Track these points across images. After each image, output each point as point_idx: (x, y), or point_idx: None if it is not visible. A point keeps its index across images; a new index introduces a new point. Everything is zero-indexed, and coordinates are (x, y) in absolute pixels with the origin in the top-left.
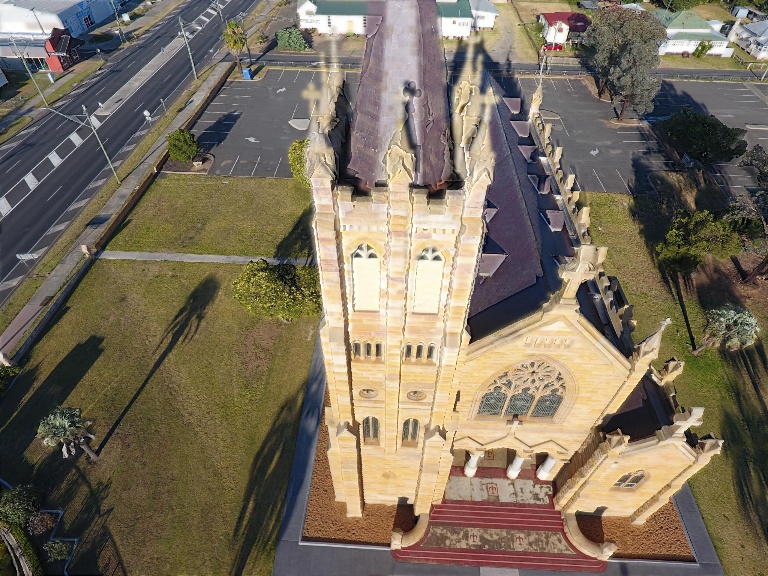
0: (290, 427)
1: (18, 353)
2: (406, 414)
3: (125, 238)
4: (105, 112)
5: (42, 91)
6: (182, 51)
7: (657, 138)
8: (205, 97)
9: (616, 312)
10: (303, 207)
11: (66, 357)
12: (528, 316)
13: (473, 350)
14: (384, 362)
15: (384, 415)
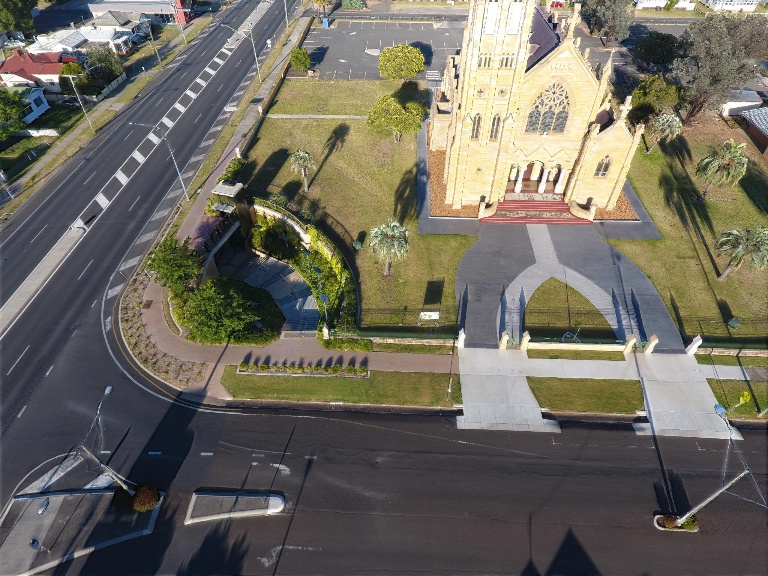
0: (412, 181)
1: (242, 154)
2: (496, 110)
3: (278, 108)
4: (231, 46)
5: (177, 36)
6: (269, 11)
7: (632, 56)
8: (299, 37)
9: (593, 71)
10: (390, 94)
11: (269, 157)
12: None
13: (527, 75)
14: (491, 68)
15: (485, 111)
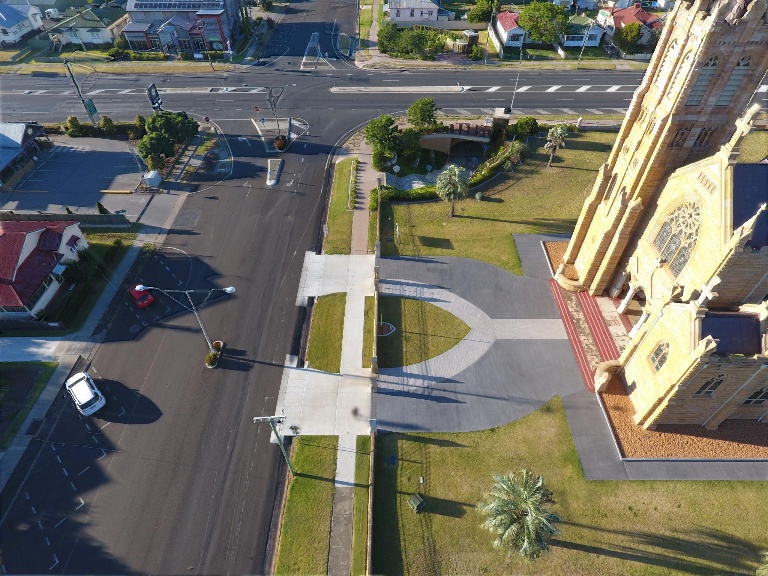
0: None
1: (585, 127)
2: (626, 180)
3: None
4: None
5: None
6: None
7: None
8: None
9: None
10: None
11: (593, 142)
12: None
13: (680, 169)
14: None
15: None
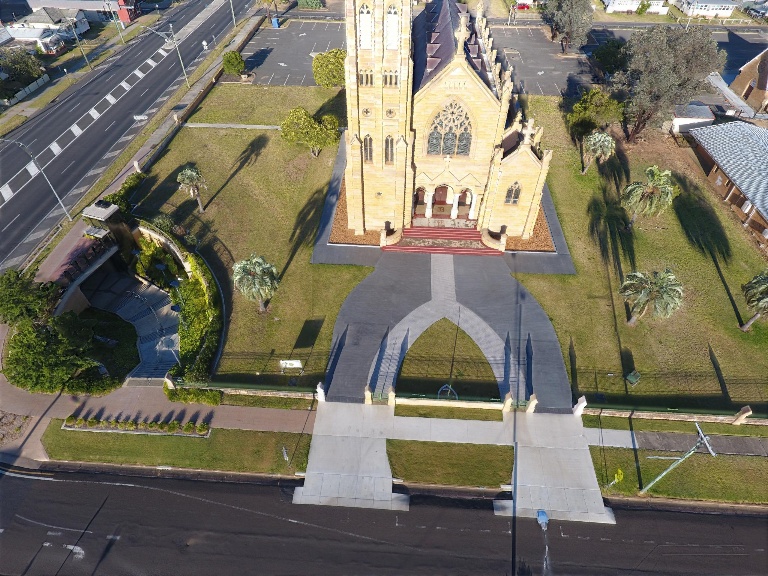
0: (319, 202)
1: (144, 167)
2: (386, 131)
3: (199, 116)
4: (169, 47)
5: (117, 34)
6: (221, 9)
7: (590, 65)
8: (244, 38)
9: None
10: (323, 102)
11: (174, 171)
12: (444, 68)
13: (420, 94)
14: (374, 86)
15: (375, 133)
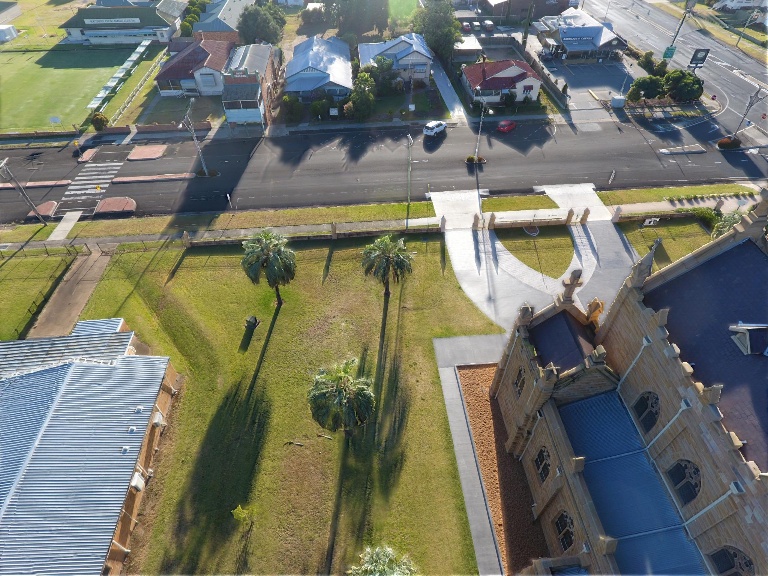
0: None
1: None
2: None
3: None
4: None
5: None
6: None
7: None
8: None
9: None
10: None
11: None
12: None
13: None
14: None
15: None
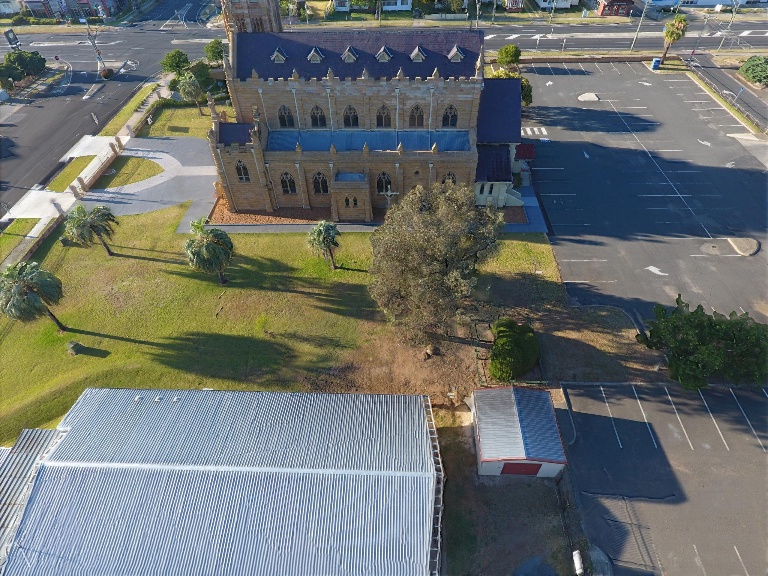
0: None
1: None
2: None
3: None
4: (551, 36)
5: (568, 17)
6: None
7: None
8: None
9: None
10: None
11: None
12: None
13: None
14: None
15: None
